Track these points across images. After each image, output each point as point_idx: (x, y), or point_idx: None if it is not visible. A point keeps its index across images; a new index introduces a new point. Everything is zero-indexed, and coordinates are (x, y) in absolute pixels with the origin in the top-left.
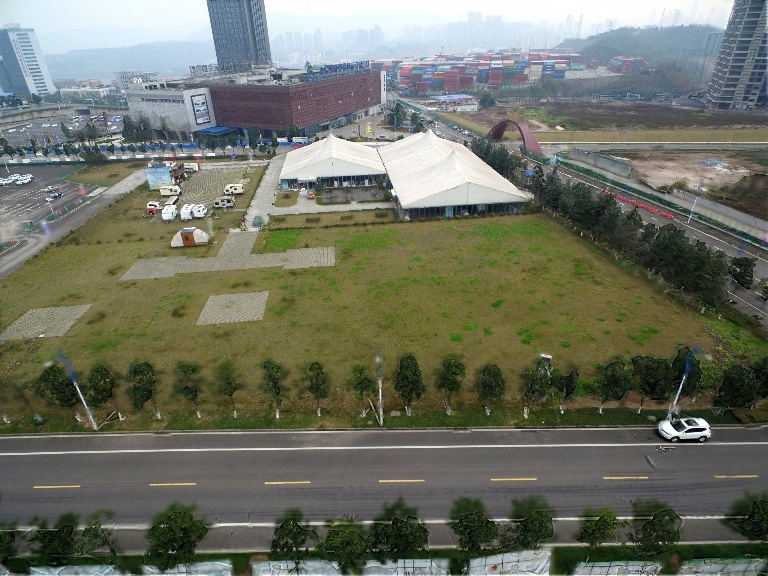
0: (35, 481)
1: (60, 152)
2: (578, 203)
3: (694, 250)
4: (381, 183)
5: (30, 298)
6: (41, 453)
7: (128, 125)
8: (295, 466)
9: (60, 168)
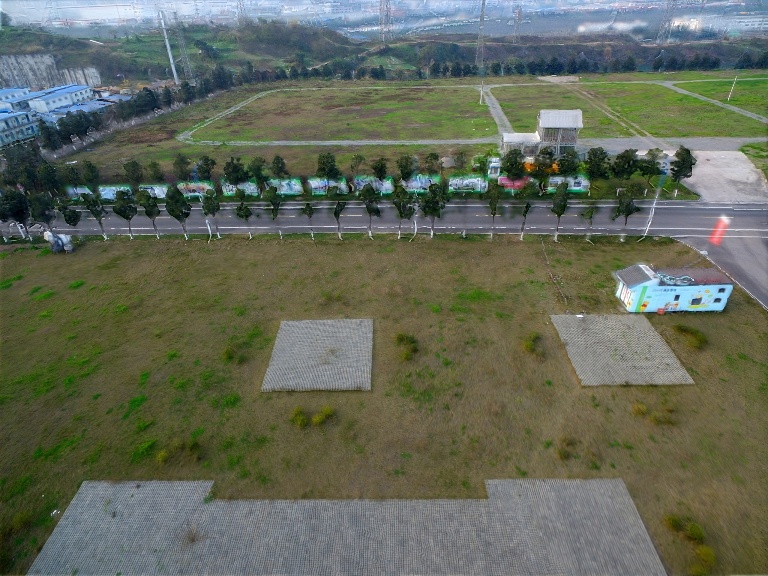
0: None
1: None
2: None
3: None
4: None
5: (760, 426)
6: (445, 227)
7: None
8: (276, 221)
9: None
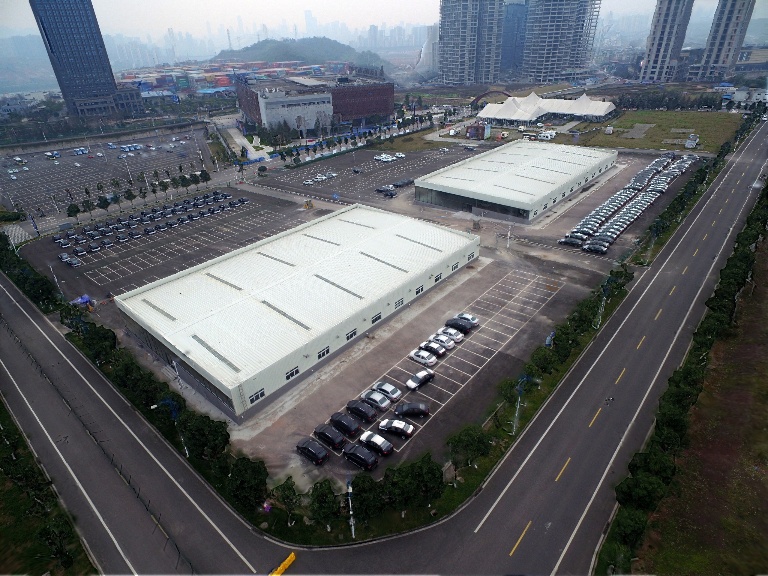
0: (762, 140)
1: (322, 147)
2: (653, 99)
3: (713, 97)
4: (551, 117)
5: None
6: None
7: (316, 124)
8: None
9: (357, 154)
